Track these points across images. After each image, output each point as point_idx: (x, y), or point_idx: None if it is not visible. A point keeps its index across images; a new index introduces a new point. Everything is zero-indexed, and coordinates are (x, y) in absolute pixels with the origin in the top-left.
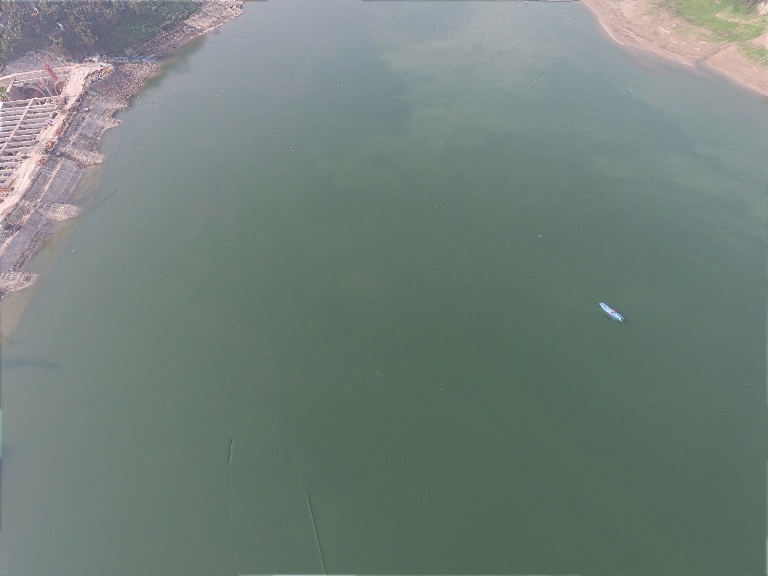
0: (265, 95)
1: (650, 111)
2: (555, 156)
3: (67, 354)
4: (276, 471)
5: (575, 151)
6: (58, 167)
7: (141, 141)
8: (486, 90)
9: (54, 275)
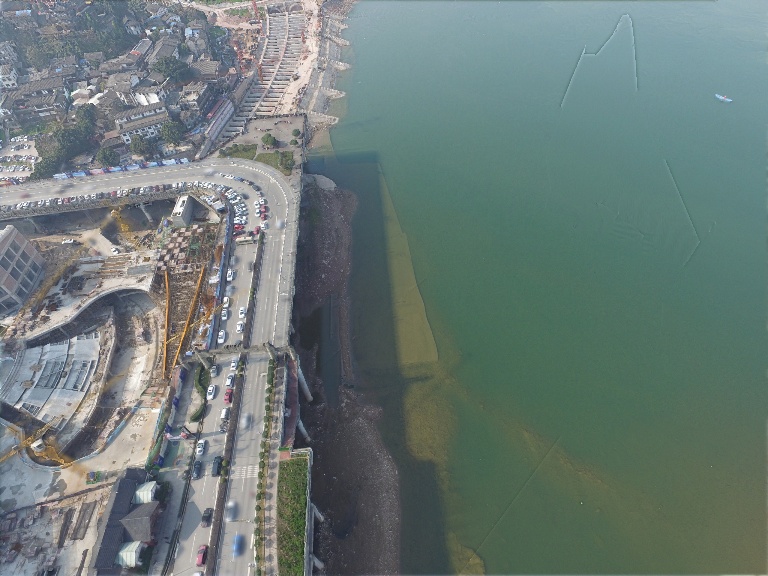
0: (444, 10)
1: (733, 11)
2: (666, 36)
3: None
4: (614, 52)
5: (680, 33)
6: (328, 44)
7: (371, 33)
8: (606, 3)
9: (355, 92)
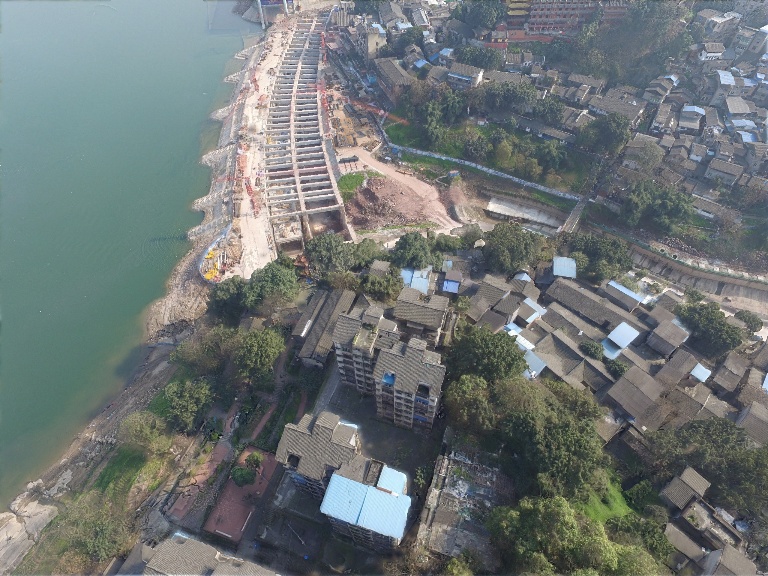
0: None
1: None
2: None
3: (193, 56)
4: None
5: None
6: (232, 133)
7: (162, 175)
8: None
9: (213, 82)
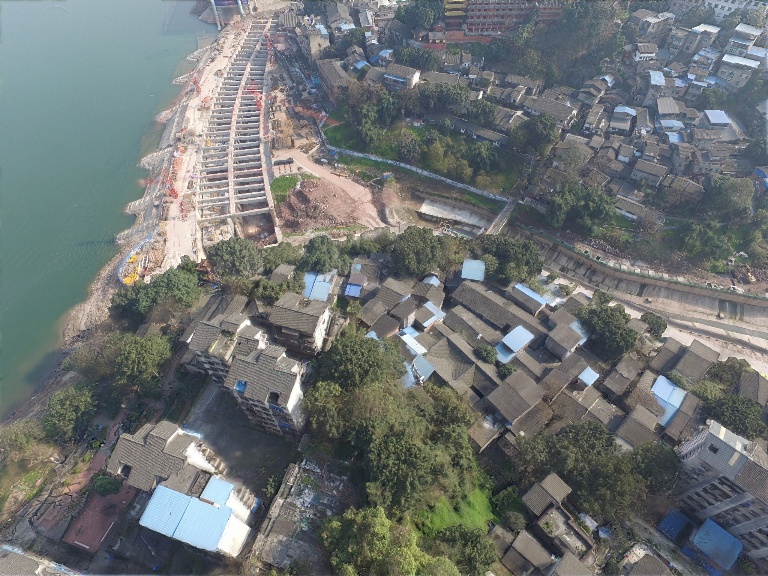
0: None
1: None
2: None
3: (144, 57)
4: None
5: None
6: (172, 136)
7: (97, 178)
8: None
9: (162, 84)
